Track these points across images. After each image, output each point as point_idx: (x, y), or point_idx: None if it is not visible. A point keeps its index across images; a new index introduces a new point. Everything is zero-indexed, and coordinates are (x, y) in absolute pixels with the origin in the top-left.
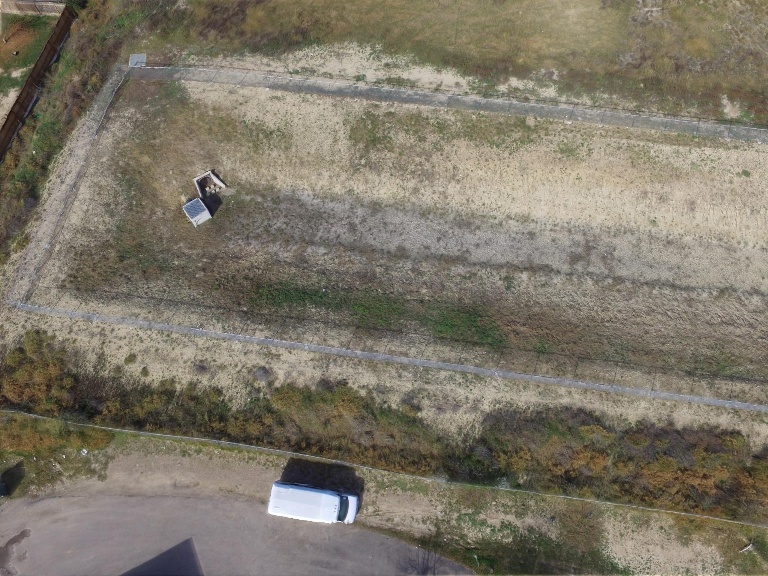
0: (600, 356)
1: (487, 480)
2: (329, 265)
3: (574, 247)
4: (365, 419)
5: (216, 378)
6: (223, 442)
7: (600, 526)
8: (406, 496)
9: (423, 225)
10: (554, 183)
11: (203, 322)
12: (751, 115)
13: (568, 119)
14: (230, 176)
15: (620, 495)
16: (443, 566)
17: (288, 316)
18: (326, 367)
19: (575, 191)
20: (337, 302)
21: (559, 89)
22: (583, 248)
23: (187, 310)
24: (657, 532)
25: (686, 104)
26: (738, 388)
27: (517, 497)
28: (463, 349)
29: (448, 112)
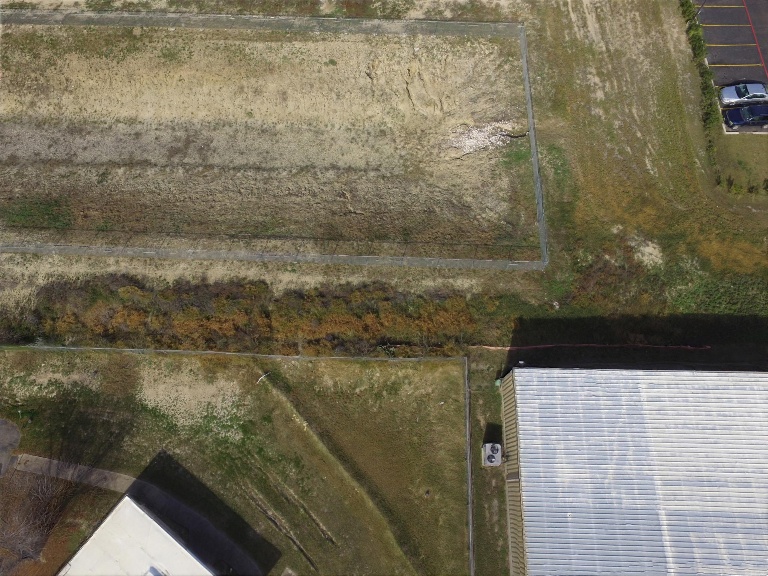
0: (156, 229)
1: (20, 341)
2: None
3: (175, 142)
4: None
5: None
6: None
7: (136, 374)
8: None
9: (38, 135)
10: (159, 86)
11: None
12: (343, 10)
13: (172, 26)
14: None
15: (149, 344)
16: None
17: None
18: None
19: (178, 92)
20: None
21: (170, 0)
22: (183, 143)
23: None
24: (186, 374)
25: (286, 5)
26: (271, 244)
27: (64, 357)
28: (28, 234)
29: (61, 29)
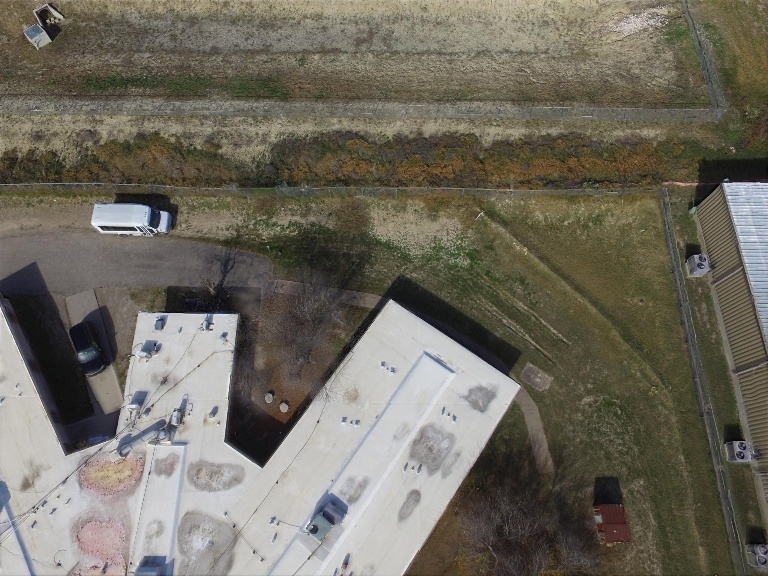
0: (367, 96)
1: (269, 183)
2: (152, 64)
3: (360, 34)
4: (174, 158)
5: (51, 144)
6: (57, 187)
7: (367, 215)
8: (212, 213)
9: (234, 30)
10: None
11: (38, 105)
12: None
13: None
14: (67, 9)
15: None
16: (241, 256)
17: (111, 94)
18: (141, 124)
19: None
20: (154, 83)
21: None
22: (367, 34)
23: (24, 98)
24: (412, 214)
25: None
26: (475, 105)
27: (301, 202)
28: (255, 101)
29: None
